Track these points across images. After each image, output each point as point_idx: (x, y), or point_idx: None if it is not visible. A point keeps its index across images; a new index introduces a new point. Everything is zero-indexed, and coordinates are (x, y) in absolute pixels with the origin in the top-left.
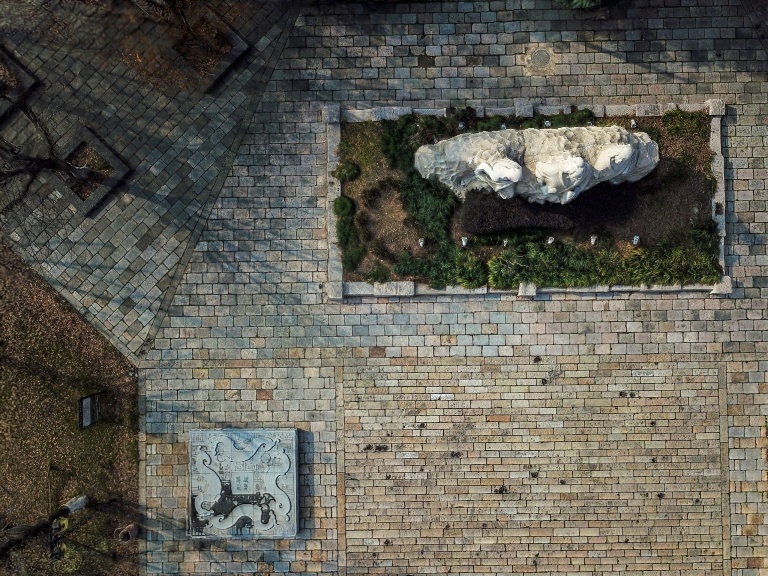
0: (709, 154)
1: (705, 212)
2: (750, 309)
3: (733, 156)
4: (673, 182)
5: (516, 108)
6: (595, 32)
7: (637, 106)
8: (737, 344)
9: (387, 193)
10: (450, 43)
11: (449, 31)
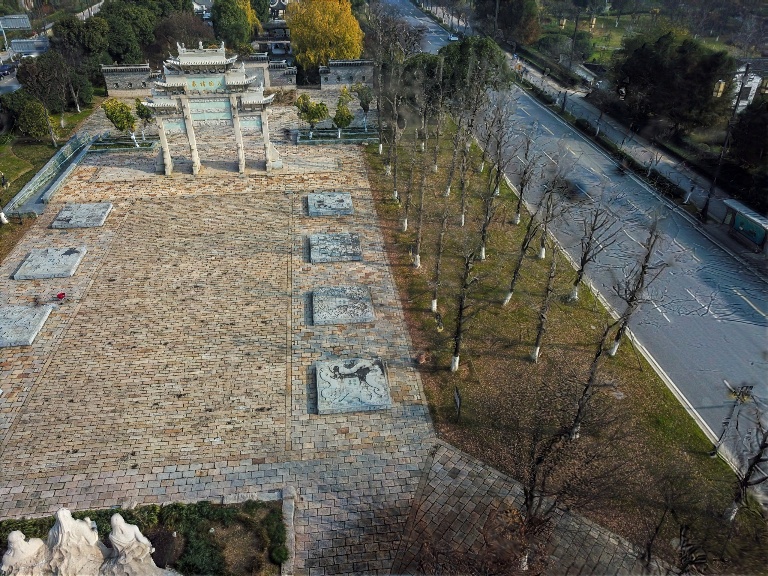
0: None
1: None
2: None
3: None
4: None
5: None
6: None
7: None
8: None
9: (239, 570)
10: None
11: None
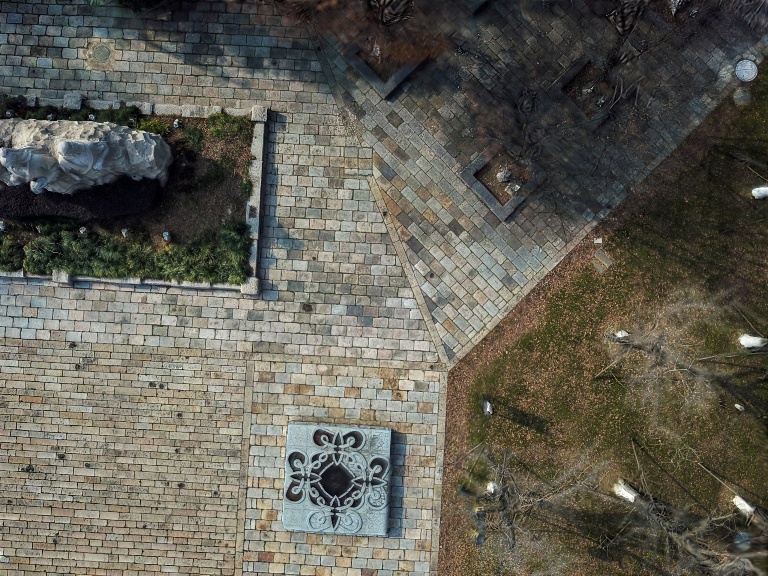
0: (248, 158)
1: (239, 214)
2: (282, 312)
3: (279, 162)
4: (210, 183)
5: (64, 100)
6: (156, 32)
7: (184, 107)
8: (267, 344)
9: None
10: (17, 32)
11: (16, 21)
